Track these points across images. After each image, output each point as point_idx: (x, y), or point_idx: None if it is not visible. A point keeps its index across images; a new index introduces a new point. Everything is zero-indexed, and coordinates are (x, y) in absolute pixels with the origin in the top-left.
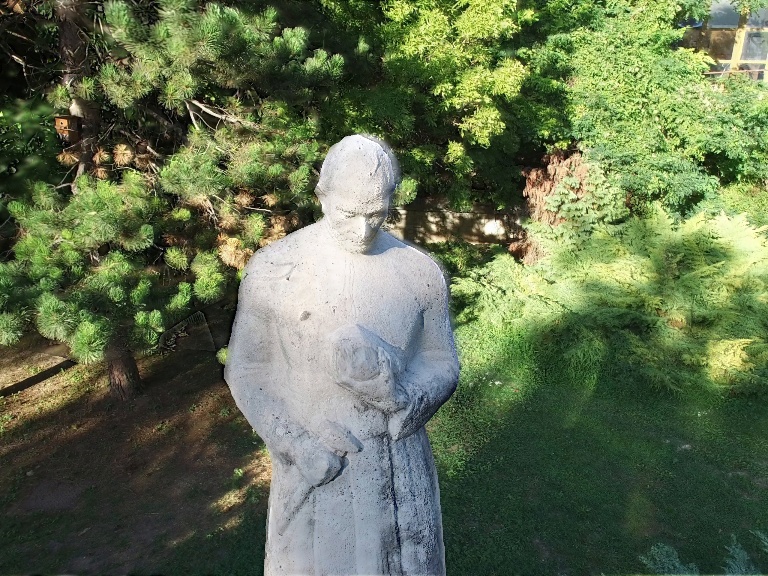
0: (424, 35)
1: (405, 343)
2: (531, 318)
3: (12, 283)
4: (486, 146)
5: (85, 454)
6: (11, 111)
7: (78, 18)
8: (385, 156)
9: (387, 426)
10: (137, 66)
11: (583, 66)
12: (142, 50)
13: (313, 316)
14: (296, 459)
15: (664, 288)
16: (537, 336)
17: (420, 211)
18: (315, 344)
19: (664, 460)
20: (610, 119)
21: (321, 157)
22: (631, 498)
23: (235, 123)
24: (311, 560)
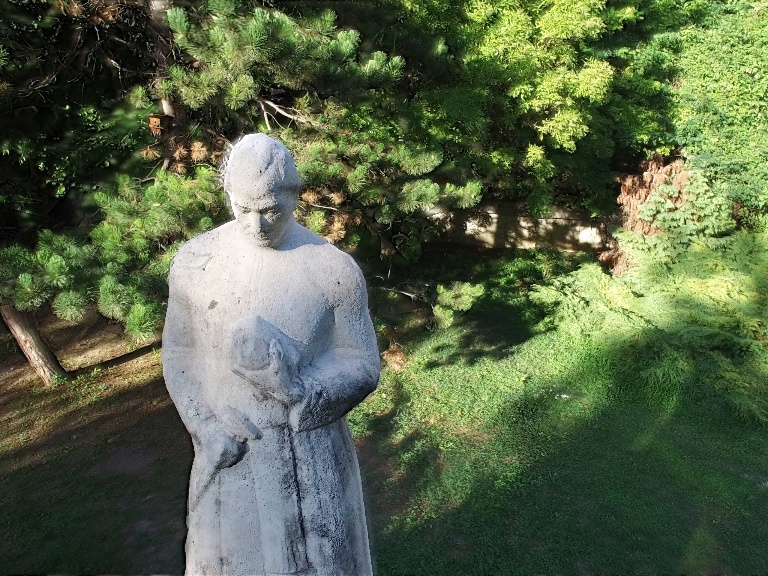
0: (505, 36)
1: (308, 338)
2: (611, 332)
3: (82, 266)
4: (572, 150)
5: (160, 428)
6: (107, 110)
7: (156, 25)
8: (282, 154)
9: (288, 418)
10: (206, 69)
11: (693, 67)
12: (203, 54)
13: (220, 306)
14: (201, 441)
15: (764, 309)
16: (615, 351)
17: (512, 216)
18: (220, 332)
19: (738, 495)
20: (720, 124)
21: (387, 158)
22: (691, 532)
23: (305, 123)
24: (218, 539)
